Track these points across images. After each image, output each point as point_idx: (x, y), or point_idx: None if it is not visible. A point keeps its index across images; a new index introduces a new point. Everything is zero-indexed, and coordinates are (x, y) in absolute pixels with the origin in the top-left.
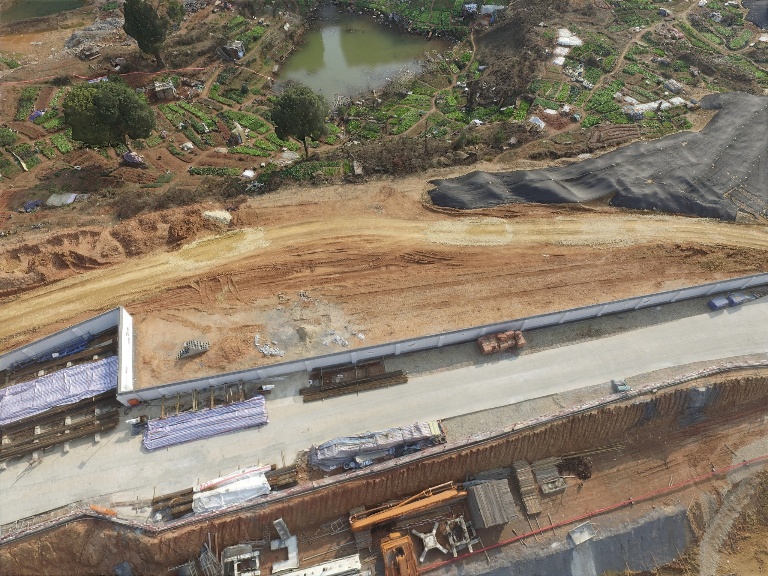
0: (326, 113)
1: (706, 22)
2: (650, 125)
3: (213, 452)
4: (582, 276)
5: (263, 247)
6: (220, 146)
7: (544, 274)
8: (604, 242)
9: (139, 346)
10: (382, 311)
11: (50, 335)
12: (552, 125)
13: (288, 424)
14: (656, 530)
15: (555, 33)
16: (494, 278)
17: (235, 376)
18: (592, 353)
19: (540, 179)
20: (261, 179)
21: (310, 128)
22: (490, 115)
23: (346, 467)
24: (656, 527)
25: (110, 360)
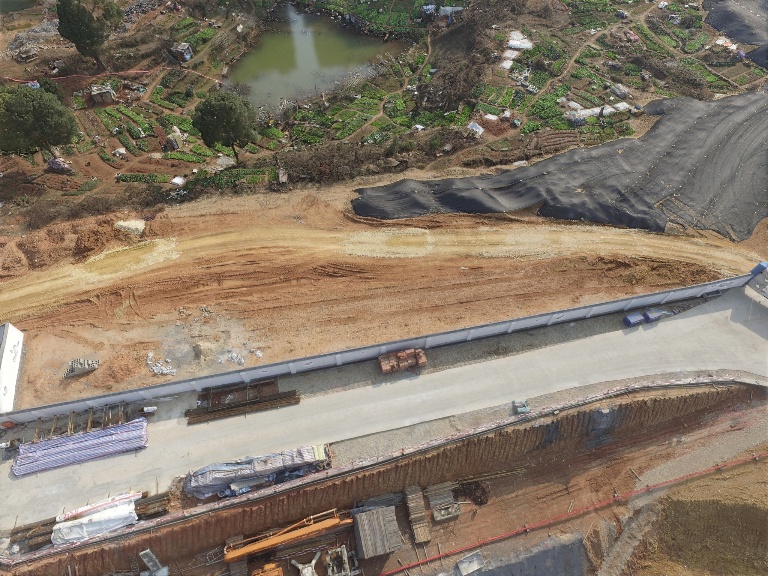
0: (253, 119)
1: (664, 24)
2: (591, 131)
3: (84, 478)
4: (498, 290)
5: (172, 259)
6: (155, 152)
7: (458, 288)
8: (526, 254)
9: (26, 364)
10: (285, 327)
11: None
12: (491, 131)
13: (168, 448)
14: (551, 559)
15: (506, 36)
16: (406, 292)
17: (116, 397)
18: (496, 372)
19: (467, 188)
20: (187, 187)
21: (235, 134)
22: (434, 120)
23: (221, 495)
24: (551, 556)
25: None
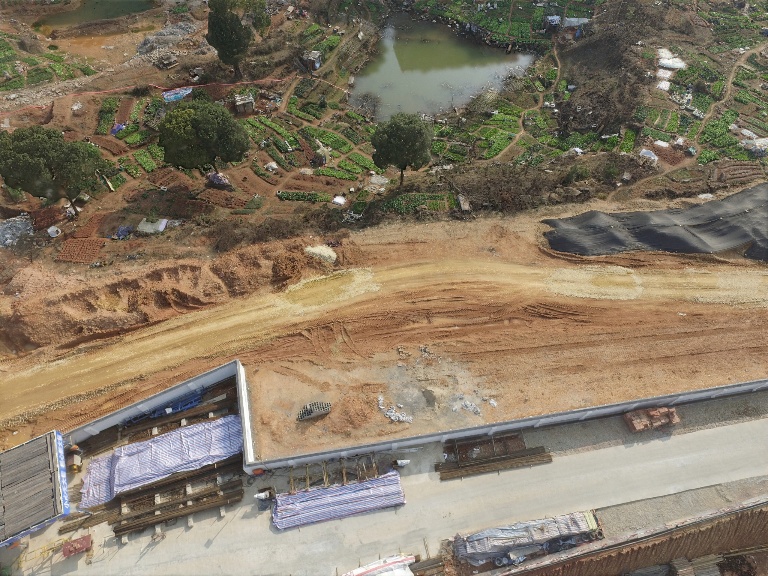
0: None
1: None
2: None
3: (349, 536)
4: (728, 341)
5: (373, 291)
6: (304, 167)
7: (685, 337)
8: (745, 301)
9: (255, 403)
10: (512, 374)
11: (166, 390)
12: (666, 159)
13: (427, 506)
14: None
15: (655, 53)
16: (631, 340)
17: (367, 448)
18: (753, 436)
19: (666, 224)
20: (356, 208)
21: (414, 158)
22: (589, 142)
23: (498, 563)
24: None
25: (228, 420)
